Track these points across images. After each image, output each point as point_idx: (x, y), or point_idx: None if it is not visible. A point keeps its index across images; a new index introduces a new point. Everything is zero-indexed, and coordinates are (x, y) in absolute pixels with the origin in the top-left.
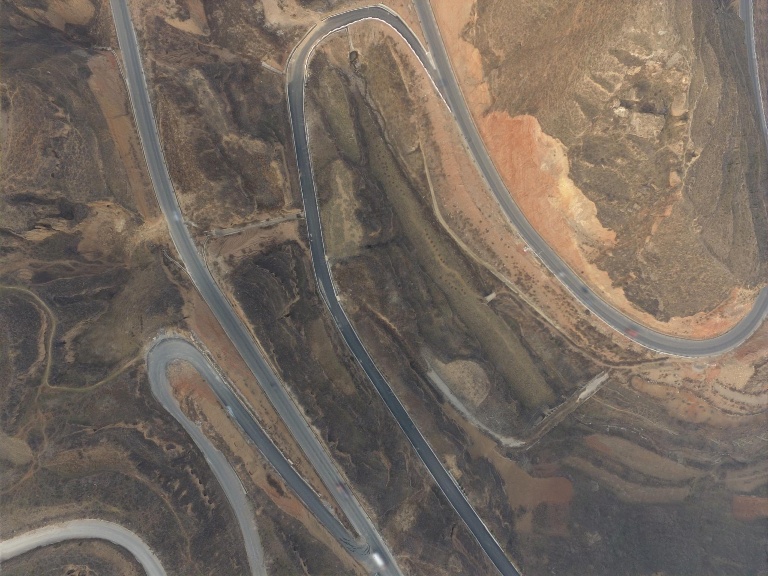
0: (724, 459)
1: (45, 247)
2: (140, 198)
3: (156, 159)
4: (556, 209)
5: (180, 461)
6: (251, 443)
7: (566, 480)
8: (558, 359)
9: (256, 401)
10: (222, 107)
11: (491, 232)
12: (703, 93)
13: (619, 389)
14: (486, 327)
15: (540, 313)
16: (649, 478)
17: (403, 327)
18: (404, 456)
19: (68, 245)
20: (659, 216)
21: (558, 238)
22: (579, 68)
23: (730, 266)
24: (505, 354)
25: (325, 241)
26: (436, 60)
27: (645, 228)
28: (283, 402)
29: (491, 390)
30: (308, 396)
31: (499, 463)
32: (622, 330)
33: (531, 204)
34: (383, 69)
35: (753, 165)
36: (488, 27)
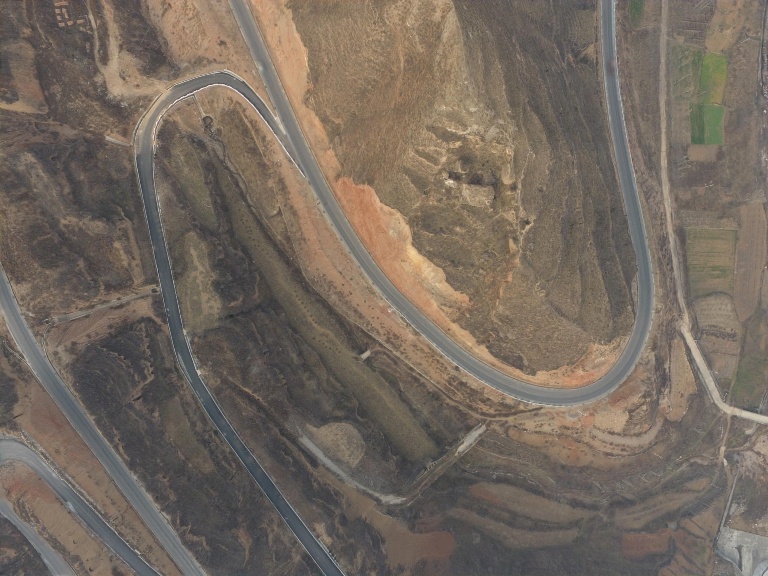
0: (613, 497)
1: None
2: None
3: None
4: (411, 273)
5: (11, 567)
6: (95, 536)
7: (448, 533)
8: (438, 412)
9: (101, 492)
10: (58, 190)
11: (354, 294)
12: (530, 162)
13: (499, 439)
14: (363, 384)
15: (415, 369)
16: (537, 522)
17: (269, 396)
18: (267, 530)
19: None
20: (504, 281)
21: (420, 298)
22: (404, 142)
23: (582, 324)
24: (384, 410)
25: (182, 315)
26: (285, 125)
27: (494, 291)
28: (132, 489)
29: (367, 450)
30: (158, 482)
31: (379, 521)
32: (493, 384)
33: (390, 266)
34: (236, 134)
35: (603, 220)
36: (323, 97)
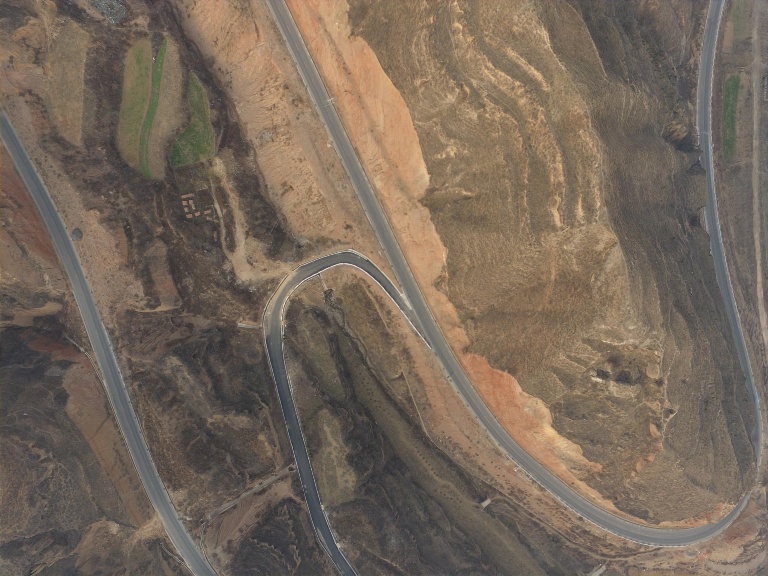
0: None
1: (42, 575)
2: (132, 507)
3: (143, 458)
4: (542, 442)
5: None
6: None
7: None
8: (556, 551)
9: None
10: (203, 390)
11: (481, 456)
12: (675, 358)
13: (617, 575)
14: (484, 531)
15: (535, 515)
16: None
17: (404, 561)
18: None
19: (65, 568)
20: (642, 458)
21: (547, 459)
22: (554, 347)
23: (714, 487)
24: (505, 554)
25: (319, 491)
26: (411, 301)
27: (630, 464)
28: None
29: None
30: None
31: None
32: (615, 531)
33: (517, 431)
34: (359, 306)
35: (728, 384)
36: (460, 289)
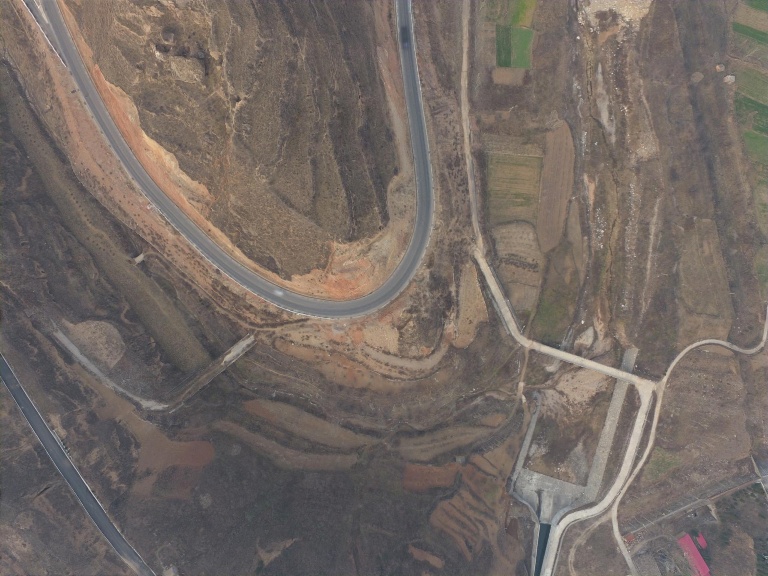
0: (401, 427)
1: None
2: None
3: None
4: (156, 163)
5: None
6: None
7: (209, 444)
8: (213, 322)
9: None
10: None
11: (115, 189)
12: (236, 35)
13: (271, 352)
14: (137, 289)
15: None
16: (315, 445)
17: (19, 285)
18: None
19: None
20: None
21: (175, 194)
22: (109, 11)
23: (318, 219)
24: (157, 317)
25: None
26: (48, 14)
27: (225, 180)
28: None
29: (126, 351)
30: None
31: (136, 426)
32: (255, 290)
33: (144, 160)
34: (8, 25)
35: (349, 116)
36: None
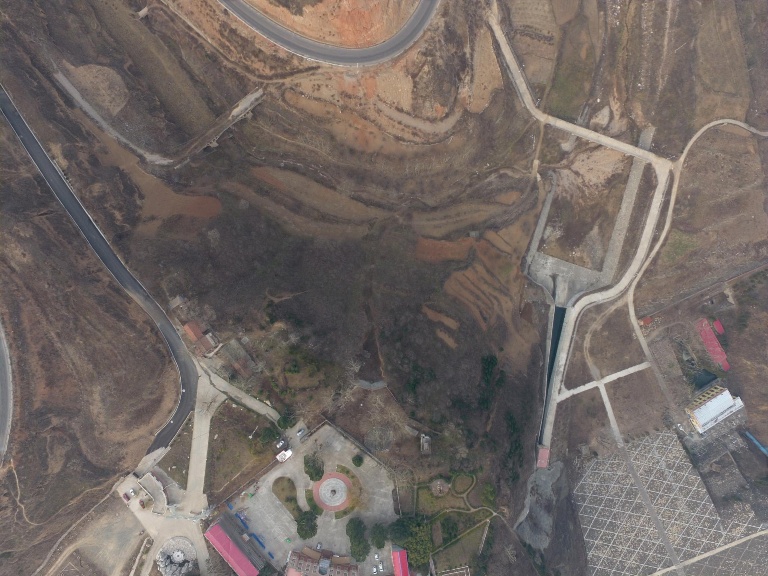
0: (413, 202)
1: None
2: None
3: None
4: None
5: None
6: None
7: (216, 200)
8: (220, 82)
9: None
10: None
11: None
12: None
13: (280, 111)
14: (141, 46)
15: (192, 26)
16: (325, 215)
17: (18, 18)
18: None
19: None
20: None
21: None
22: None
23: None
24: (162, 75)
25: None
26: None
27: None
28: None
29: (130, 99)
30: None
31: (140, 178)
32: (264, 32)
33: None
34: None
35: None
36: None
